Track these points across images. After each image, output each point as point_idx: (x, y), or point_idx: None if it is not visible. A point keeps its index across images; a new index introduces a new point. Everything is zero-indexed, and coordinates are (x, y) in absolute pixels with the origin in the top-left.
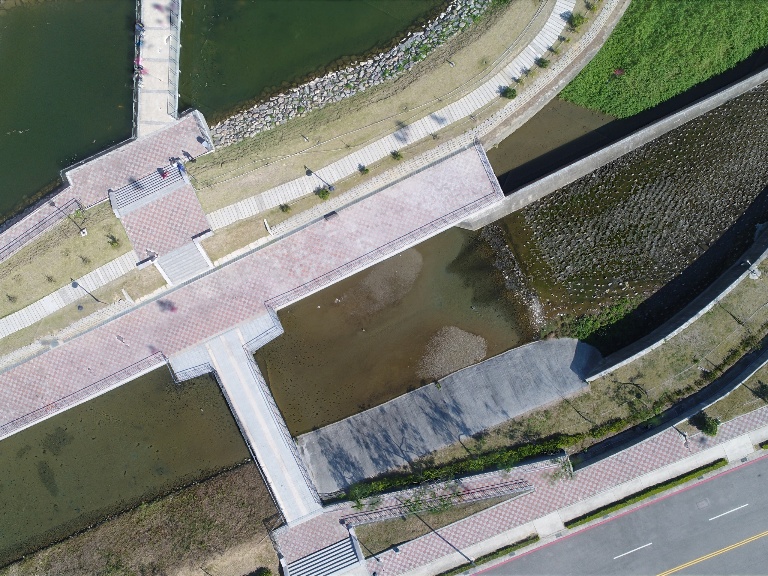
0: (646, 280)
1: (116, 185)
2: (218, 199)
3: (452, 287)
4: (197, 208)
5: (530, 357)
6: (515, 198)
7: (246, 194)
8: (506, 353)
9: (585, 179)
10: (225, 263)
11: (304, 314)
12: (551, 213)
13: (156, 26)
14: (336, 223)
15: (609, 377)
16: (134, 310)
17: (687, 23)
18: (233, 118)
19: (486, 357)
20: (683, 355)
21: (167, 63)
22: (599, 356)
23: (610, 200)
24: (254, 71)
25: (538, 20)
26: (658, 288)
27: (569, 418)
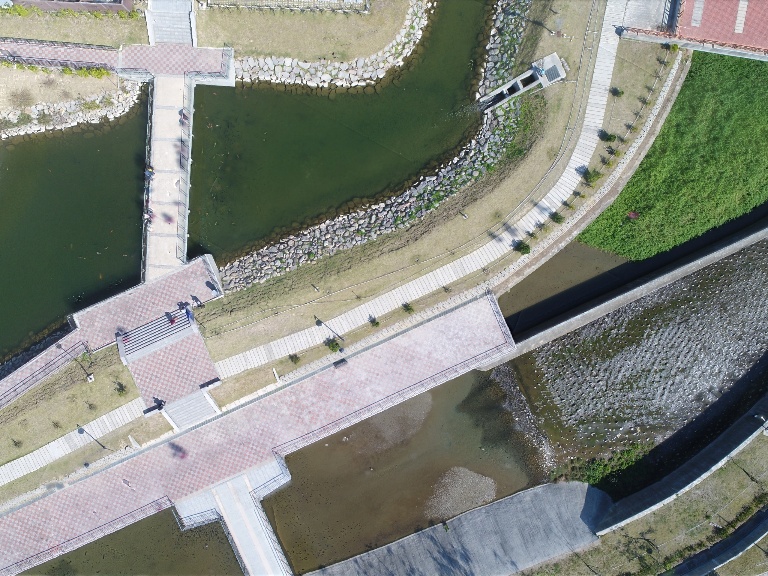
0: (658, 426)
1: (124, 328)
2: (227, 348)
3: (461, 427)
4: (205, 356)
5: (540, 502)
6: (527, 344)
7: (255, 343)
8: (515, 495)
9: (597, 322)
10: (233, 408)
11: (312, 452)
12: (563, 356)
13: (166, 169)
14: (345, 371)
15: (620, 531)
16: (140, 454)
17: (703, 169)
18: (242, 259)
19: (495, 499)
20: (695, 511)
21: (176, 207)
22: (609, 501)
23: (622, 344)
24: (264, 210)
25: (553, 174)
26: (670, 434)
27: (579, 572)
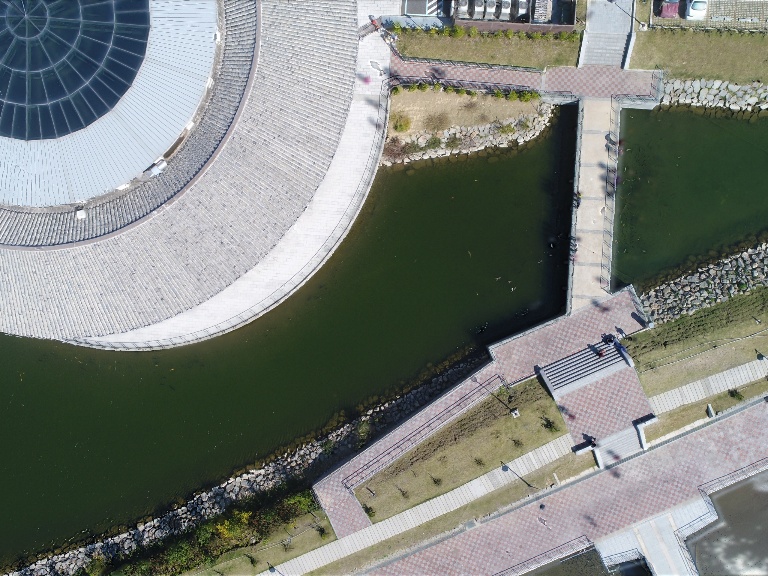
0: None
1: (543, 361)
2: (662, 382)
3: None
4: (639, 391)
5: None
6: None
7: (692, 378)
8: None
9: None
10: (656, 445)
11: None
12: None
13: (590, 196)
14: None
15: None
16: (557, 491)
17: None
18: (659, 289)
19: None
20: None
21: (601, 235)
22: None
23: None
24: (676, 238)
25: None
26: None
27: None
